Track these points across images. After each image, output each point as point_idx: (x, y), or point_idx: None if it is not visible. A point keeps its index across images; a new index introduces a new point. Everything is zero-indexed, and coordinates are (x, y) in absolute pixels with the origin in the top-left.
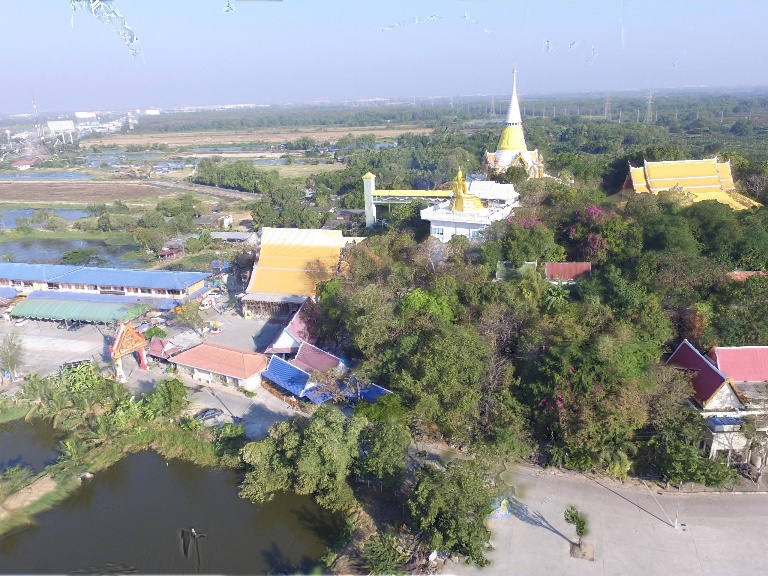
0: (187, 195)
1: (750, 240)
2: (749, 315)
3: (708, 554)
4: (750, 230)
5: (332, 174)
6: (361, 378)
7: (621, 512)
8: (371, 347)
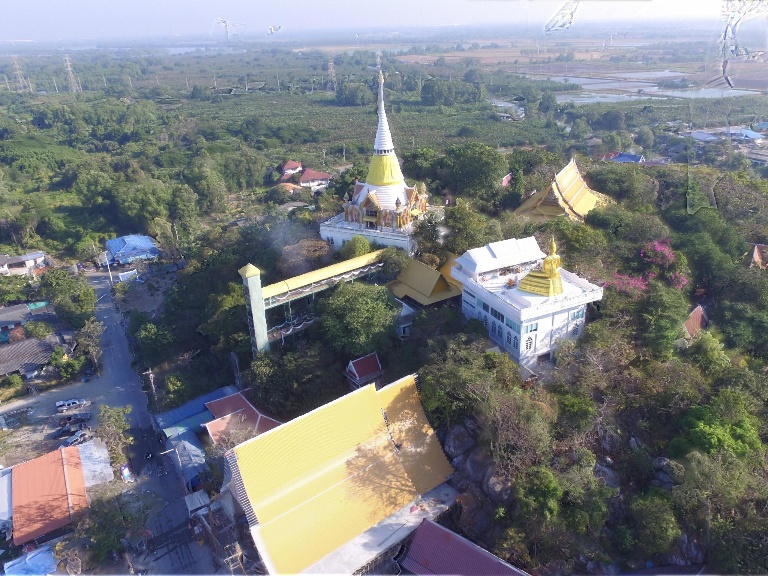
0: None
1: None
2: None
3: None
4: None
5: None
6: None
7: None
8: None
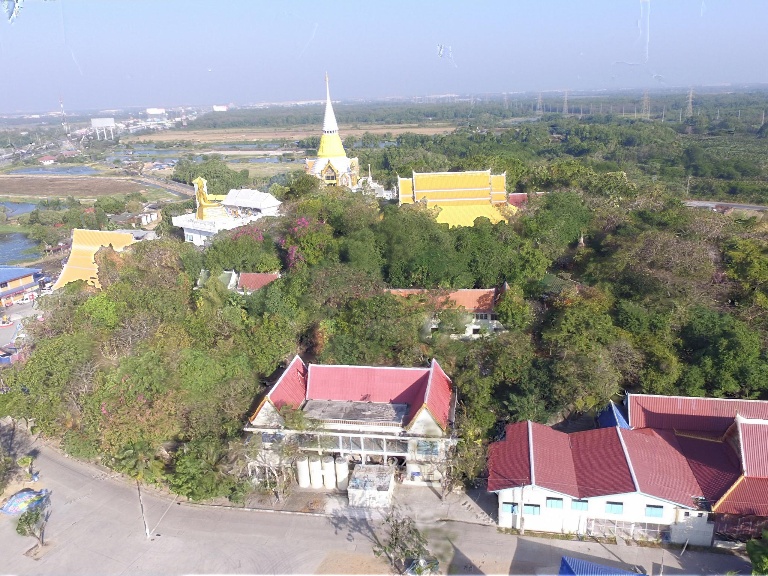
0: (135, 193)
1: (420, 257)
2: (362, 334)
3: (142, 564)
4: (435, 247)
5: (288, 174)
6: (7, 375)
7: (122, 518)
8: (27, 347)
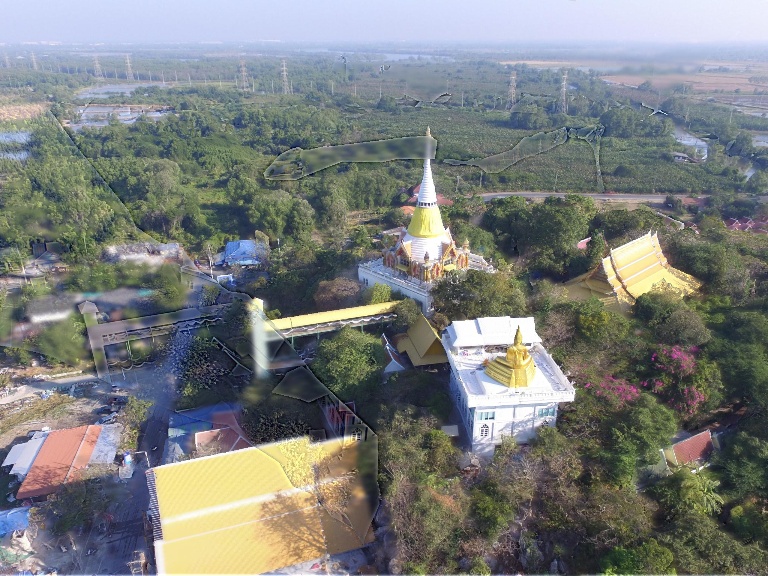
0: None
1: None
2: None
3: None
4: None
5: None
6: None
7: None
8: None
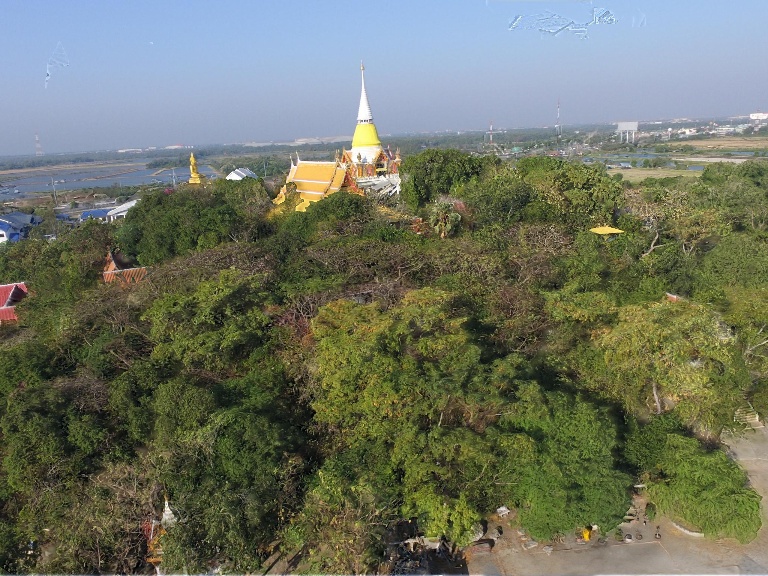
0: None
1: None
2: None
3: None
4: None
5: None
6: None
7: None
8: None
